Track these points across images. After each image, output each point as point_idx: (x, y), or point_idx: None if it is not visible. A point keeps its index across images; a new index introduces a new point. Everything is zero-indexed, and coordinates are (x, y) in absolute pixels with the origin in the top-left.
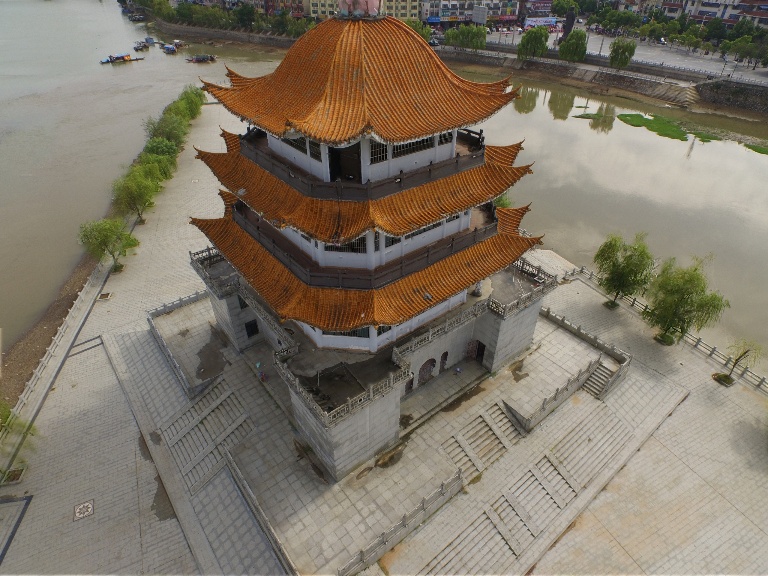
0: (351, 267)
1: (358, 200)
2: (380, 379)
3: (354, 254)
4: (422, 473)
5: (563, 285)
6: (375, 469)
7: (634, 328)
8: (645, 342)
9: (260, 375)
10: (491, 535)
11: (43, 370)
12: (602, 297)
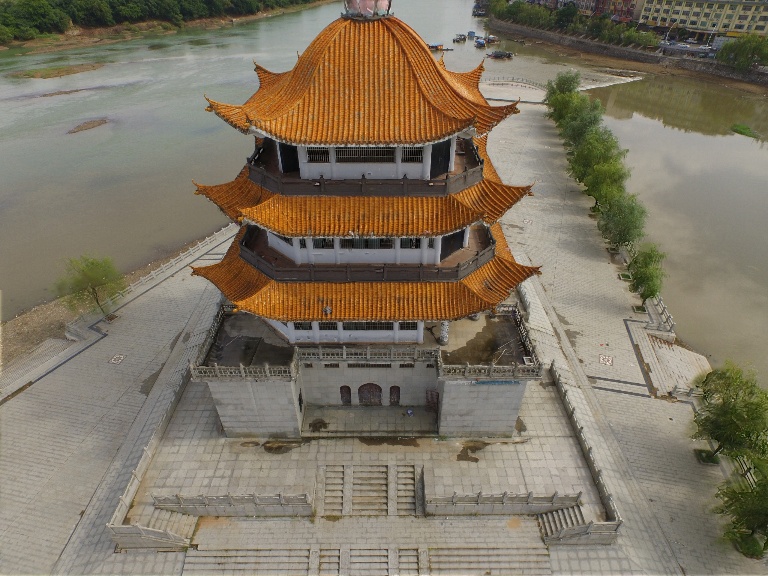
0: (286, 255)
1: (273, 191)
2: None
3: (286, 244)
4: (286, 476)
5: (659, 400)
6: (259, 447)
7: (711, 502)
8: (708, 528)
9: None
10: (298, 573)
11: (179, 261)
12: (703, 441)
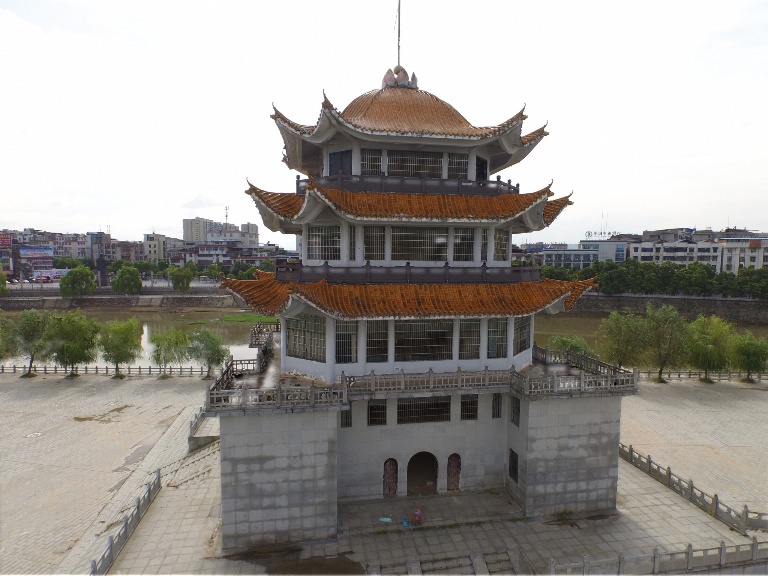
0: None
1: None
2: (571, 369)
3: (504, 262)
4: None
5: None
6: None
7: None
8: None
9: (407, 523)
10: None
11: None
12: None
